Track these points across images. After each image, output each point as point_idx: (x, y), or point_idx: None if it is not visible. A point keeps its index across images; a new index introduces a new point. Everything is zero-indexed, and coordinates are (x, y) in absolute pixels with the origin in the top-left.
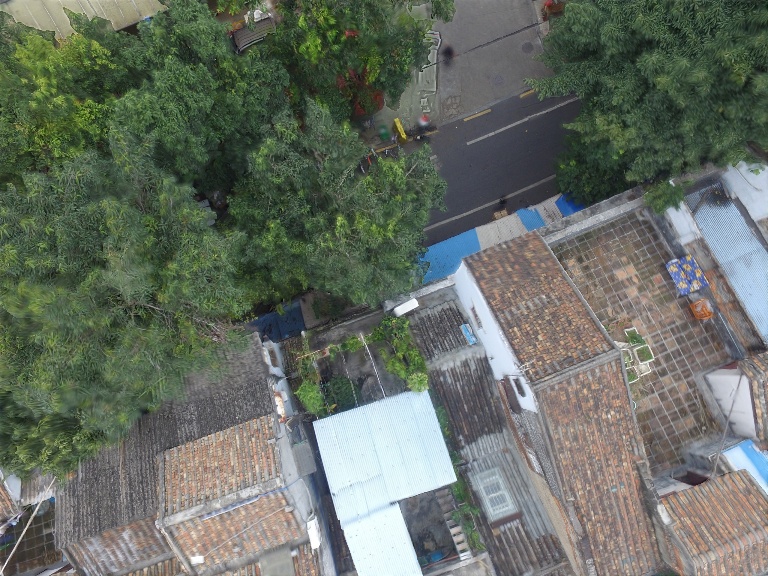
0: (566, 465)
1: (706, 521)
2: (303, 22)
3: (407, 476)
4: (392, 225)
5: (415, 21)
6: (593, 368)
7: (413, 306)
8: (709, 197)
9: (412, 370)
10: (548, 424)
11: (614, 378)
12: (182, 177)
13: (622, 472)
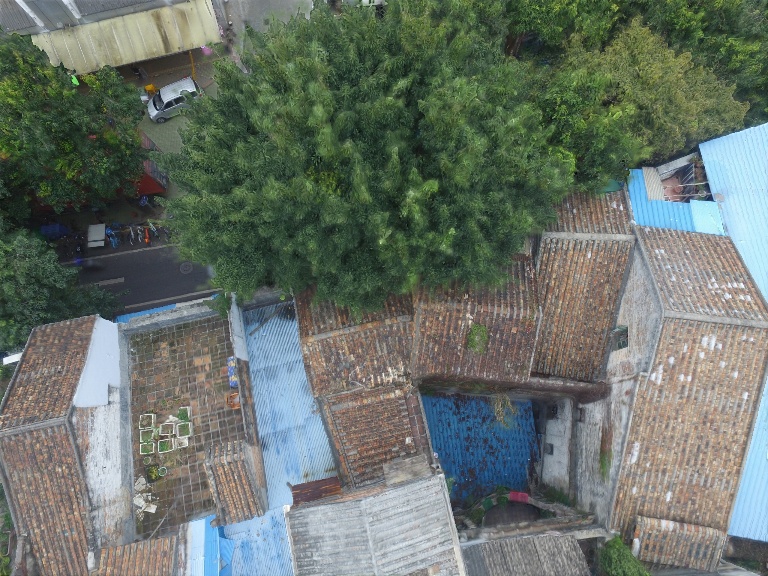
0: (22, 505)
1: (119, 573)
2: None
3: None
4: None
5: None
6: (45, 428)
7: (18, 359)
8: (282, 310)
9: None
10: (5, 467)
11: (65, 439)
12: None
13: (72, 519)
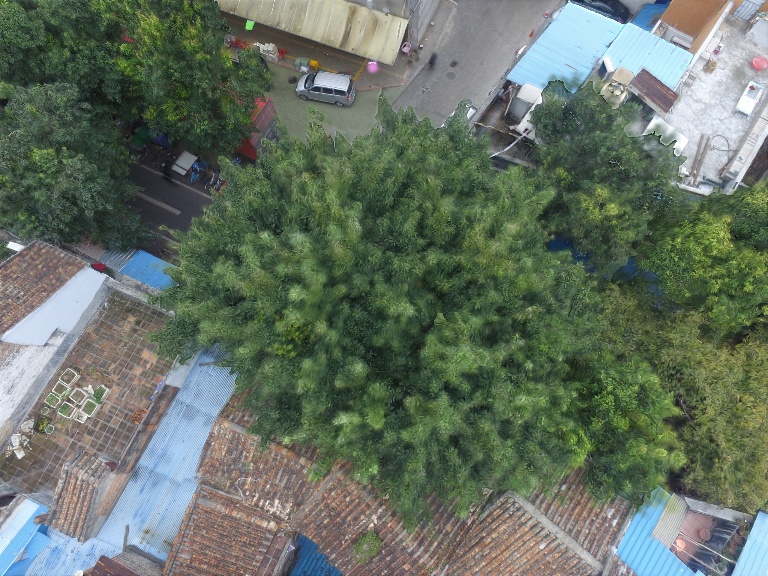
0: None
1: None
2: (123, 47)
3: None
4: None
5: None
6: None
7: (19, 250)
8: None
9: None
10: None
11: None
12: (12, 75)
13: None
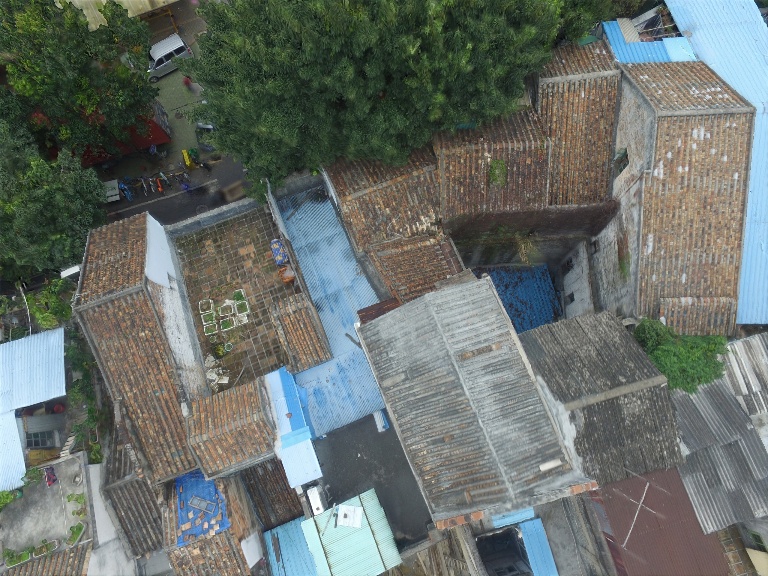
0: (113, 371)
1: (213, 415)
2: (10, 69)
3: (30, 391)
4: (18, 201)
5: (133, 72)
6: (125, 296)
7: (74, 271)
8: (313, 195)
9: (49, 313)
10: (93, 337)
11: (144, 305)
12: None
13: (160, 379)
